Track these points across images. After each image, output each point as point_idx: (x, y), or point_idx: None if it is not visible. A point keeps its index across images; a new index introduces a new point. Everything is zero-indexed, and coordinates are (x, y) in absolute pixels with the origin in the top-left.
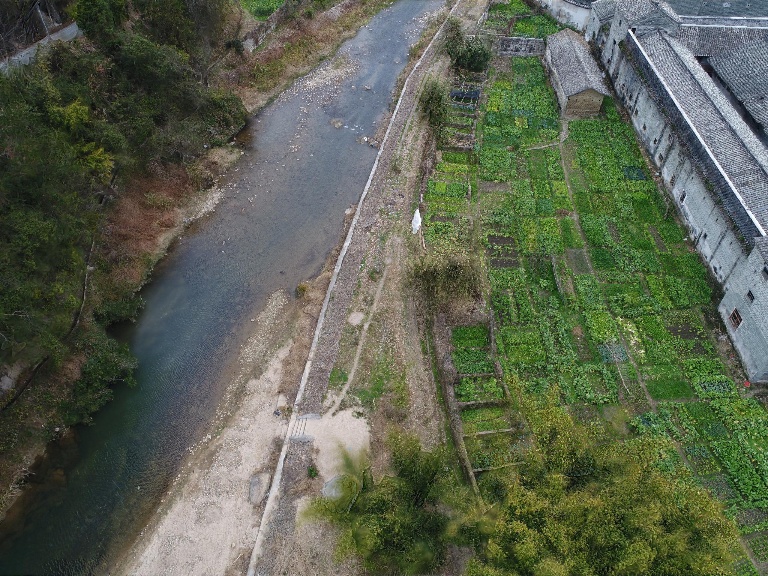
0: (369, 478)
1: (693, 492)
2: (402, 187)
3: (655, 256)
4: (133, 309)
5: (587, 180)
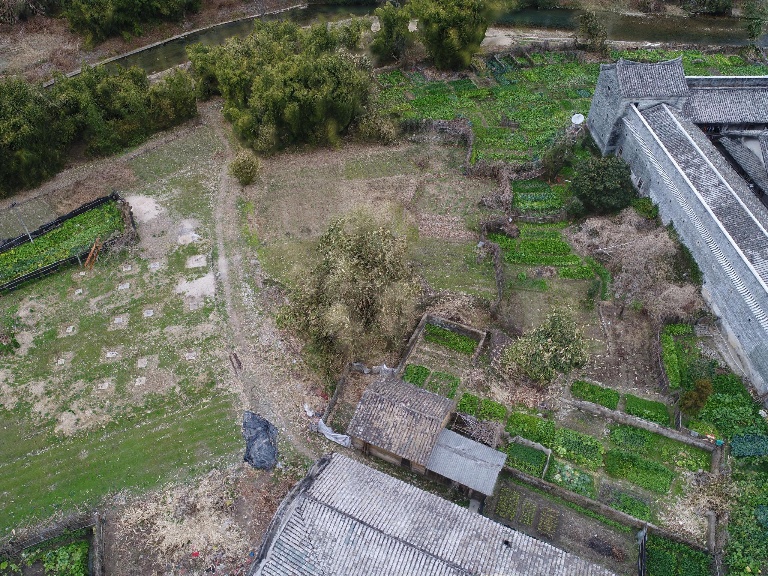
0: None
1: None
2: None
3: None
4: (544, 4)
5: None
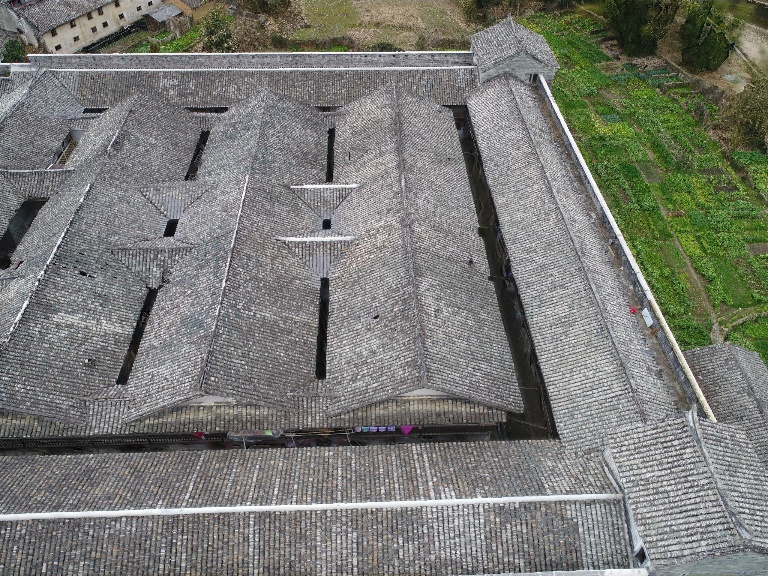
0: None
1: (566, 74)
2: None
3: None
4: None
5: None
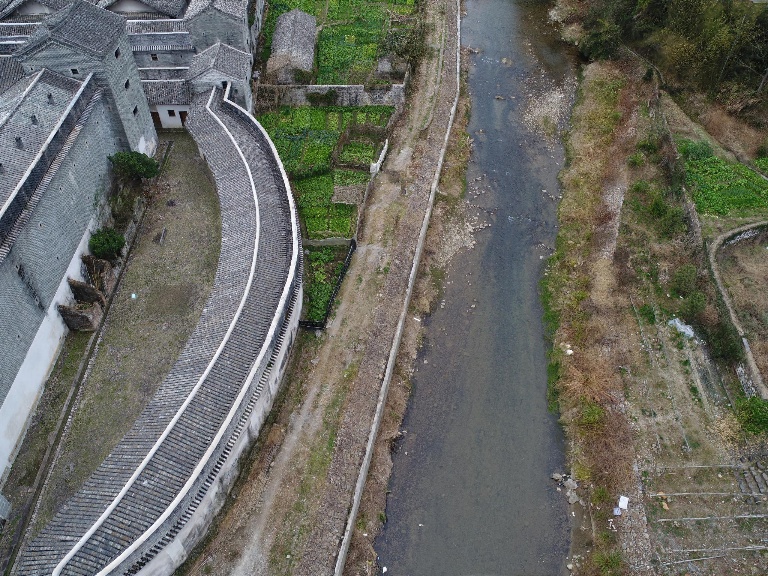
0: None
1: None
2: (435, 7)
3: None
4: None
5: (314, 5)
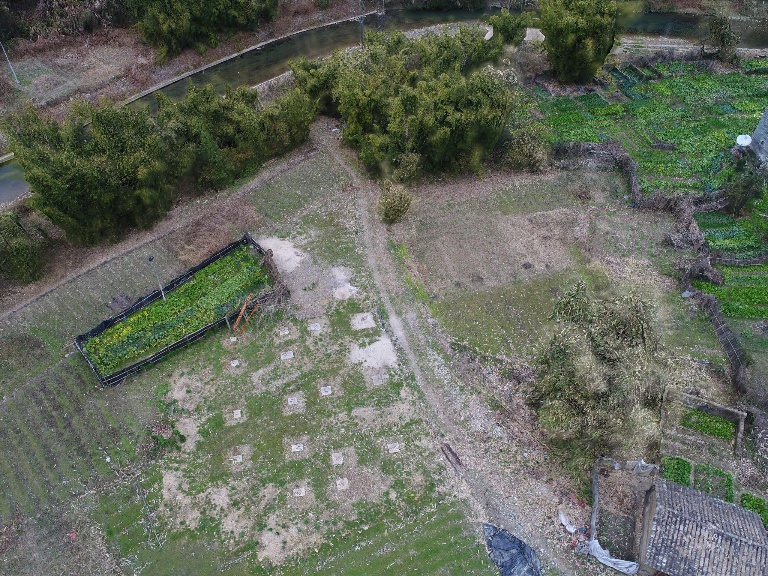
0: None
1: None
2: None
3: None
4: (639, 8)
5: None
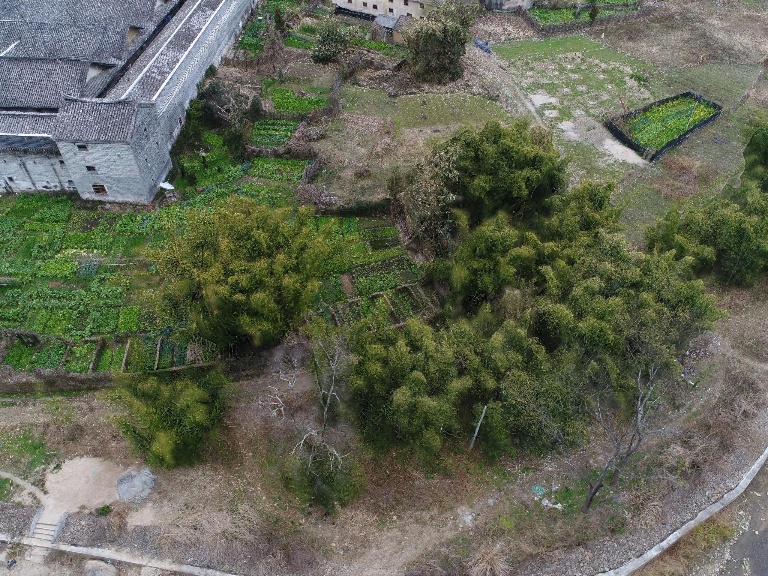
0: (141, 430)
1: None
2: None
3: (5, 218)
4: None
5: None
